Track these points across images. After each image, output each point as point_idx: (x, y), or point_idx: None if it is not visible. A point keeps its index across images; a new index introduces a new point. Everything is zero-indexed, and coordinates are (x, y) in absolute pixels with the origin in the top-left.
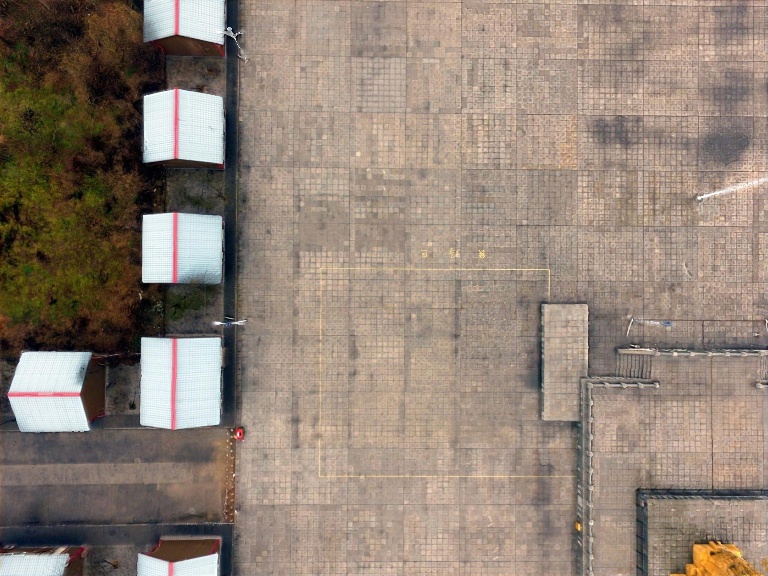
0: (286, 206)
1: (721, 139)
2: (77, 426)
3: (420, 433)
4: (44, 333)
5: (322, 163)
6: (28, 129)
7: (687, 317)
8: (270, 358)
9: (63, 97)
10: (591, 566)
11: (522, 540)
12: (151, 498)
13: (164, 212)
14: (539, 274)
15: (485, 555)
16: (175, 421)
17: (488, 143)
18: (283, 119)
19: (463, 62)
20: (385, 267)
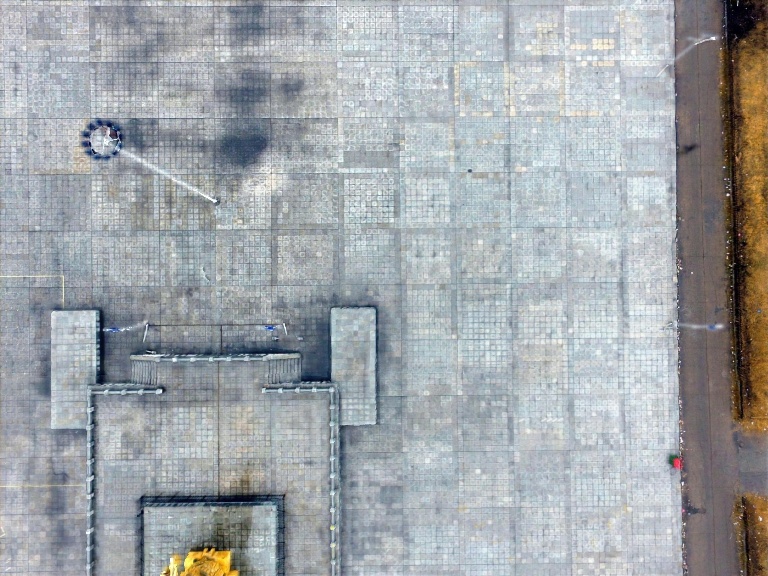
0: None
1: (238, 141)
2: None
3: None
4: None
5: None
6: None
7: (205, 322)
8: None
9: None
10: (89, 575)
11: (35, 550)
12: None
13: None
14: (53, 280)
15: None
16: None
17: None
18: None
19: None
20: None
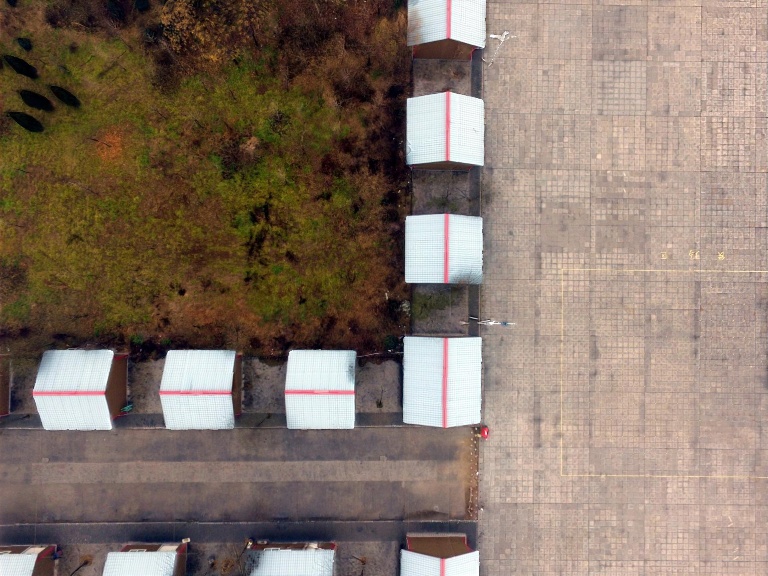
0: (528, 207)
1: None
2: (344, 423)
3: (660, 433)
4: (295, 332)
5: (563, 165)
6: (277, 131)
7: None
8: (513, 358)
9: (311, 99)
10: None
11: (762, 540)
12: (396, 495)
13: (410, 213)
14: None
15: (725, 555)
16: (446, 419)
17: (727, 146)
18: (525, 121)
19: (703, 65)
20: (625, 268)
